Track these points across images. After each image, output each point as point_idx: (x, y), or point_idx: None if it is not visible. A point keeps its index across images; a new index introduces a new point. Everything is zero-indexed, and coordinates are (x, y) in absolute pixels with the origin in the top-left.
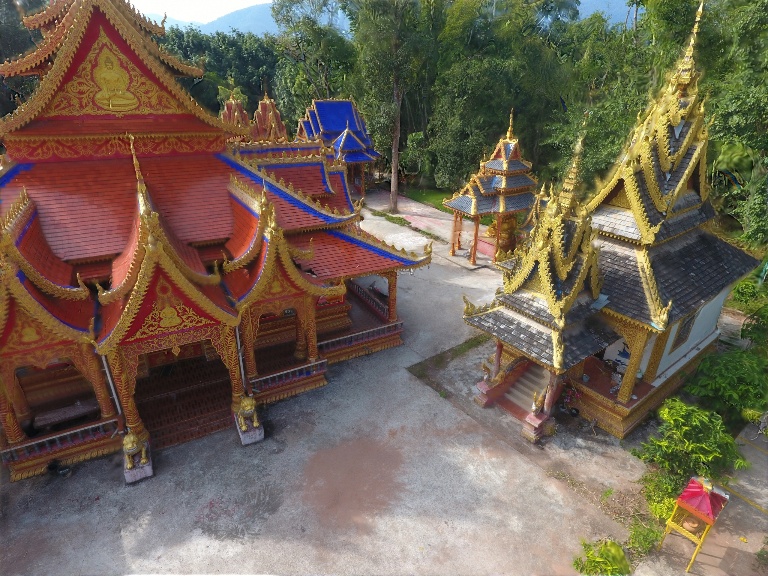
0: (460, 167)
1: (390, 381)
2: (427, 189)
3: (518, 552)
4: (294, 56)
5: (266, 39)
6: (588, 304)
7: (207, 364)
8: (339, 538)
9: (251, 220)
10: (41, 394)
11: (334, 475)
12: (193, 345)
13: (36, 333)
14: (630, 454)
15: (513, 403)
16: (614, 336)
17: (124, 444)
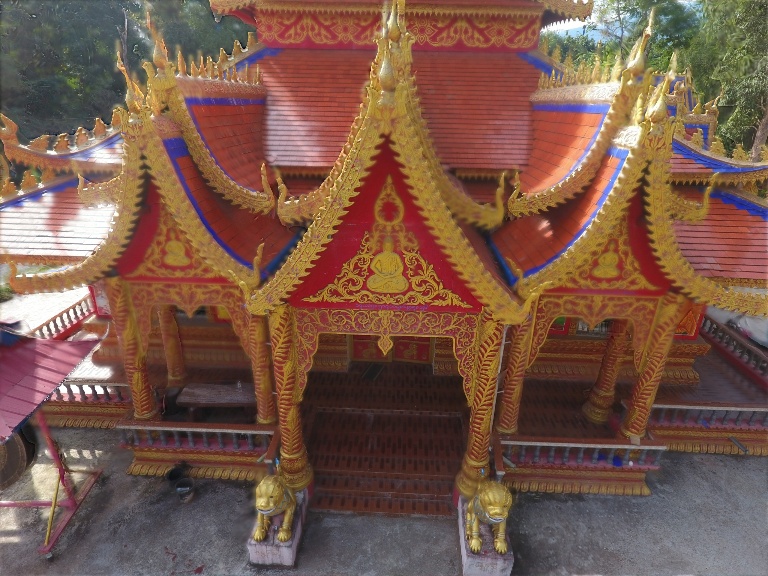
0: None
1: None
2: None
3: None
4: (609, 32)
5: (568, 35)
6: None
7: (432, 379)
8: None
9: (581, 124)
10: (216, 355)
11: None
12: (418, 343)
13: (185, 253)
14: None
15: None
16: None
17: None
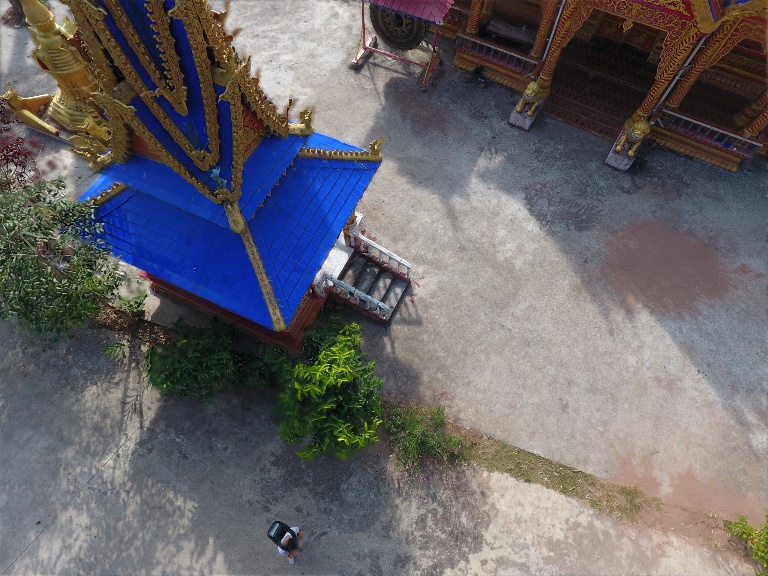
0: None
1: None
2: None
3: (733, 453)
4: None
5: None
6: None
7: (644, 64)
8: (604, 292)
9: None
10: (507, 2)
11: (650, 250)
12: (649, 34)
13: None
14: None
15: None
16: None
17: (527, 88)
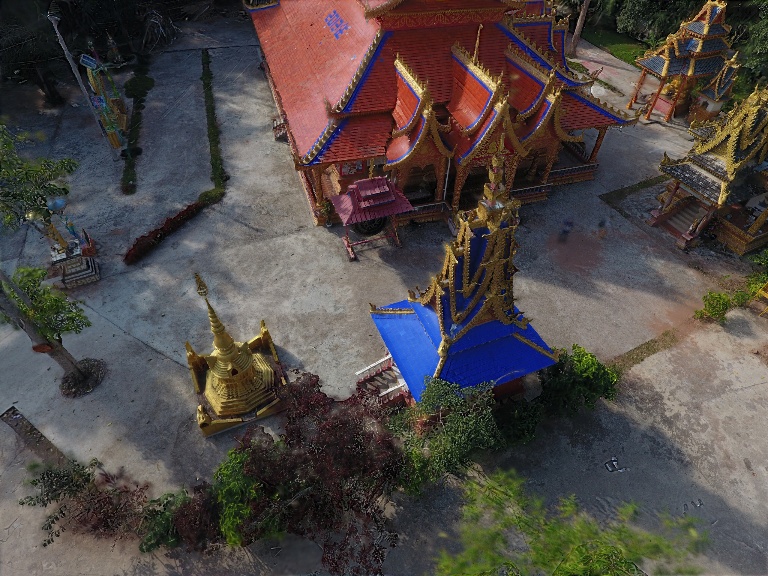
0: (647, 11)
1: (588, 203)
2: (603, 30)
3: (668, 295)
4: None
5: None
6: (753, 167)
7: (472, 177)
8: (572, 275)
9: (534, 85)
10: None
11: (563, 248)
12: None
13: (427, 149)
14: (744, 264)
15: (672, 226)
16: (763, 190)
17: None
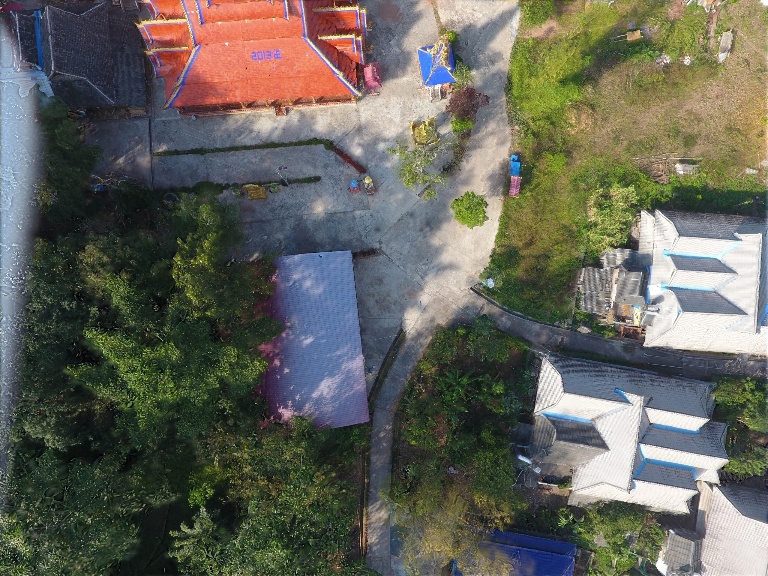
0: None
1: None
2: None
3: None
4: None
5: None
6: None
7: None
8: (402, 19)
9: None
10: None
11: (388, 16)
12: None
13: None
14: None
15: None
16: None
17: None
